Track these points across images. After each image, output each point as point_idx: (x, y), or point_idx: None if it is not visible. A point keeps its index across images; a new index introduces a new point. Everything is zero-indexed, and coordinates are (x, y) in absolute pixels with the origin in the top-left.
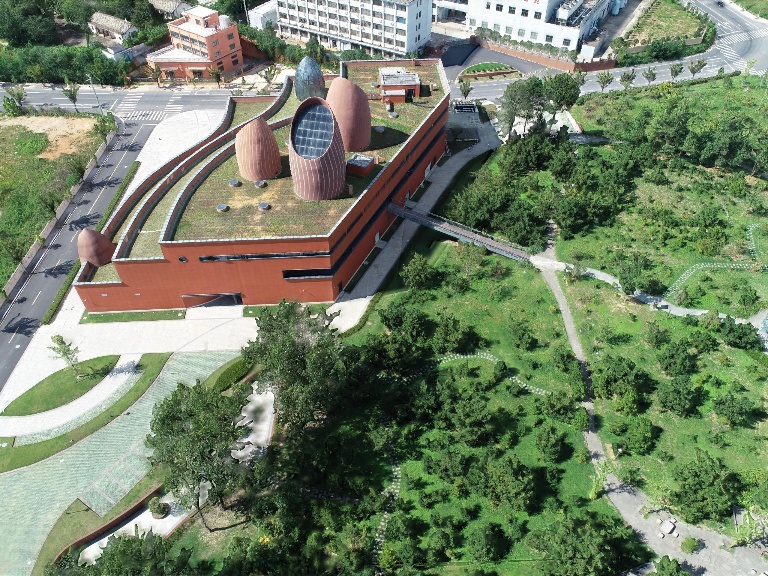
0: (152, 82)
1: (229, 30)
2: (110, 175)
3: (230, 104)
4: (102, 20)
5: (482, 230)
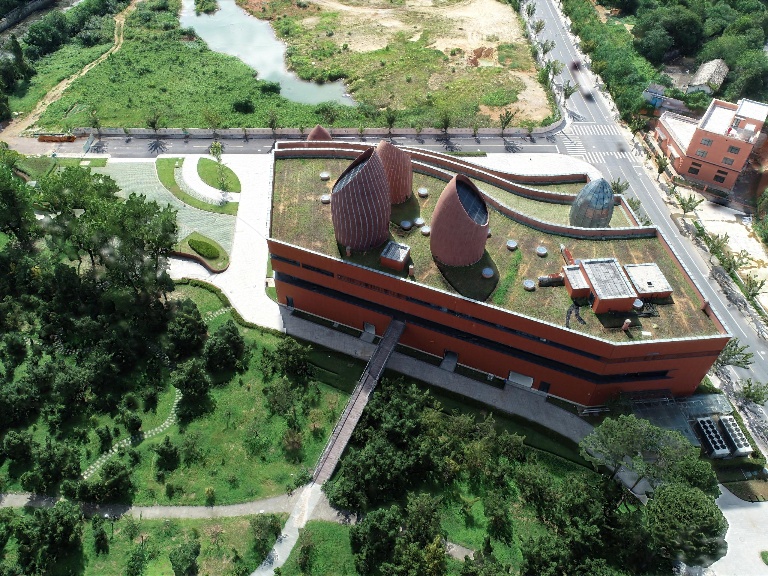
0: (641, 134)
1: (737, 142)
2: (463, 145)
3: (579, 178)
4: (709, 67)
5: (370, 426)
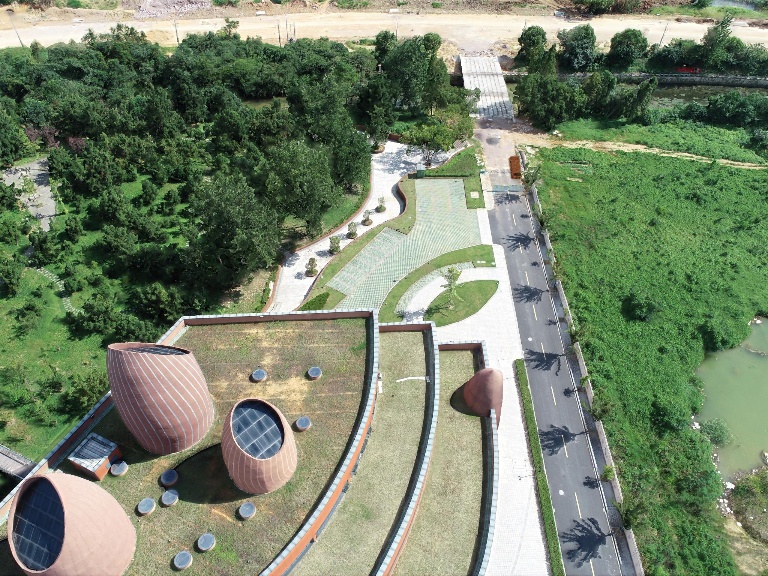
0: None
1: None
2: None
3: None
4: None
5: None
